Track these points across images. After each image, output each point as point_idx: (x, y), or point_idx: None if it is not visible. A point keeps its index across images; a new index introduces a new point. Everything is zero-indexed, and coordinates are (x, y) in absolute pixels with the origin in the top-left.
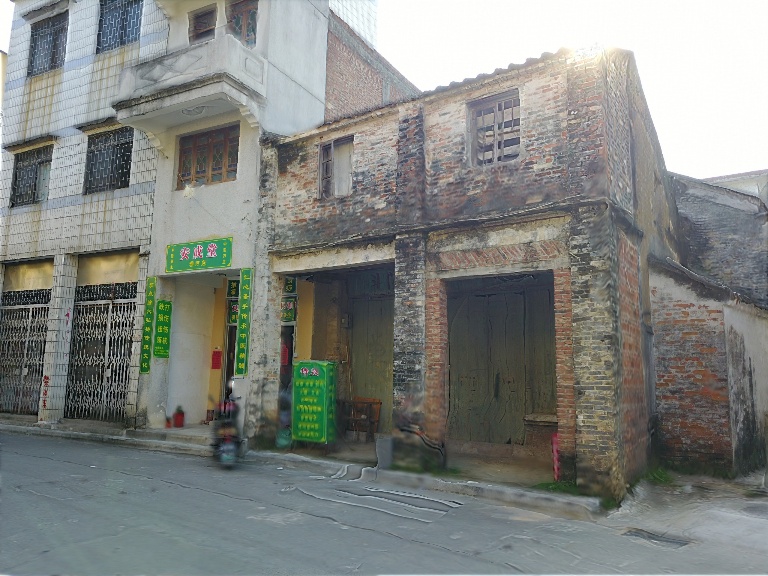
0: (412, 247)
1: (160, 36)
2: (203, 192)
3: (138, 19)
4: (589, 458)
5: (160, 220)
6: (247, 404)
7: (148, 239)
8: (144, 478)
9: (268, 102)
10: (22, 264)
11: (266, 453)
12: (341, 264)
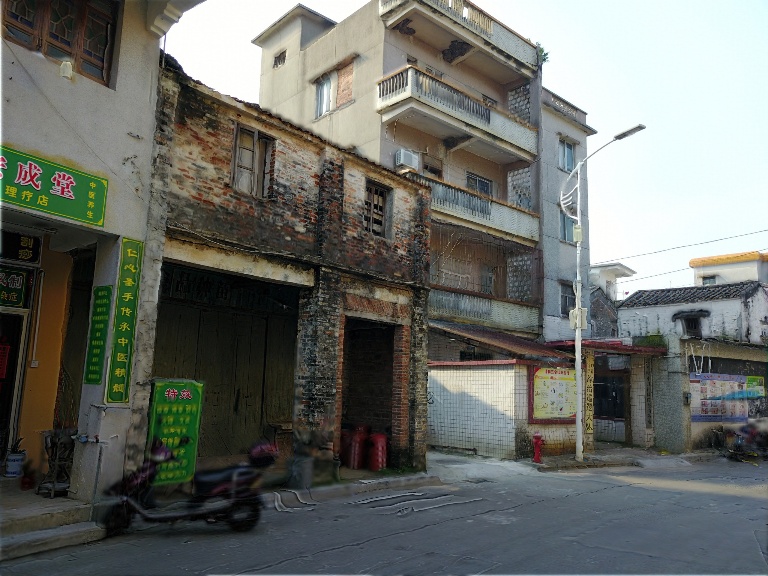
0: (335, 283)
1: None
2: (45, 69)
3: None
4: (419, 448)
5: None
6: (126, 446)
7: None
8: (305, 558)
9: None
10: None
11: (145, 512)
12: (258, 275)
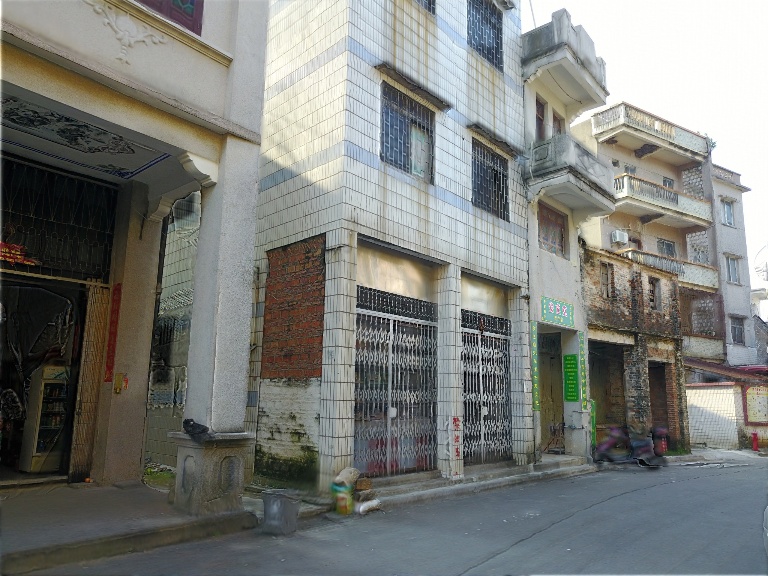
0: (644, 342)
1: (516, 88)
2: (556, 260)
3: None
4: None
5: None
6: None
7: (526, 283)
8: None
9: None
10: (378, 249)
11: None
12: (614, 341)
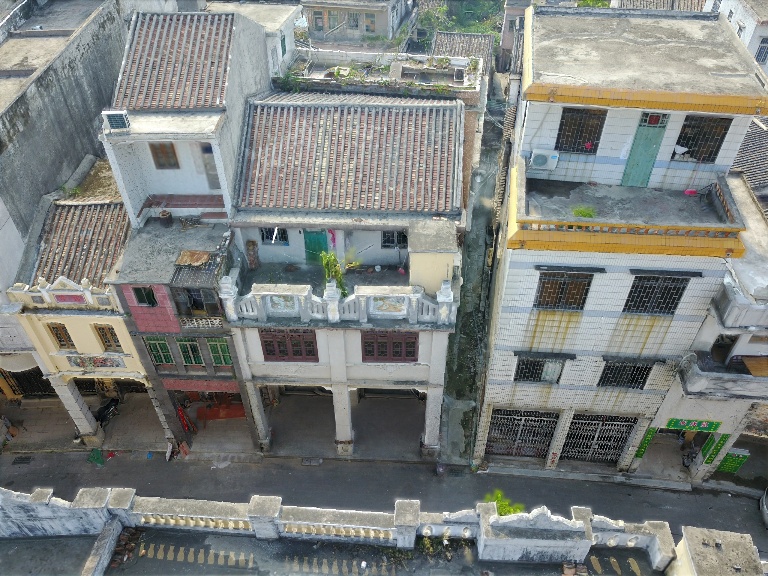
0: None
1: (694, 318)
2: (707, 402)
3: (675, 302)
4: None
5: (668, 408)
6: None
7: None
8: None
9: None
10: None
11: (710, 481)
12: None
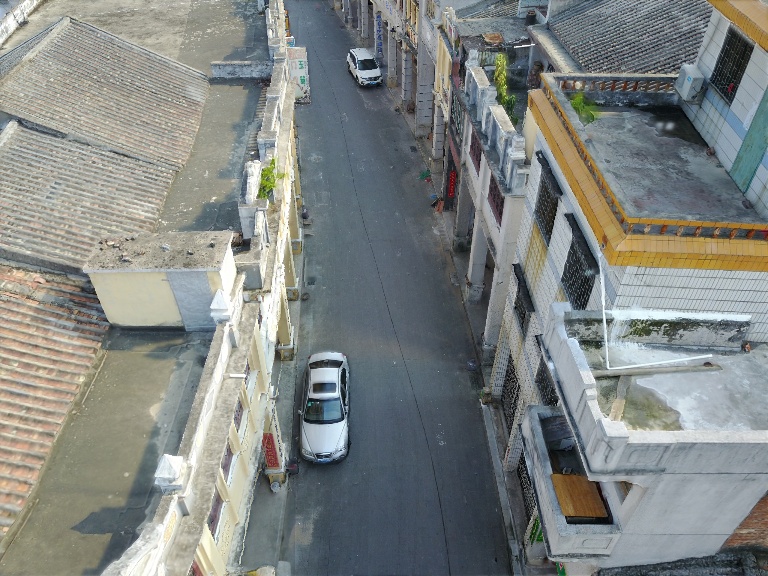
0: None
1: None
2: None
3: (584, 305)
4: None
5: None
6: None
7: None
8: None
9: (613, 554)
10: None
11: None
12: None
